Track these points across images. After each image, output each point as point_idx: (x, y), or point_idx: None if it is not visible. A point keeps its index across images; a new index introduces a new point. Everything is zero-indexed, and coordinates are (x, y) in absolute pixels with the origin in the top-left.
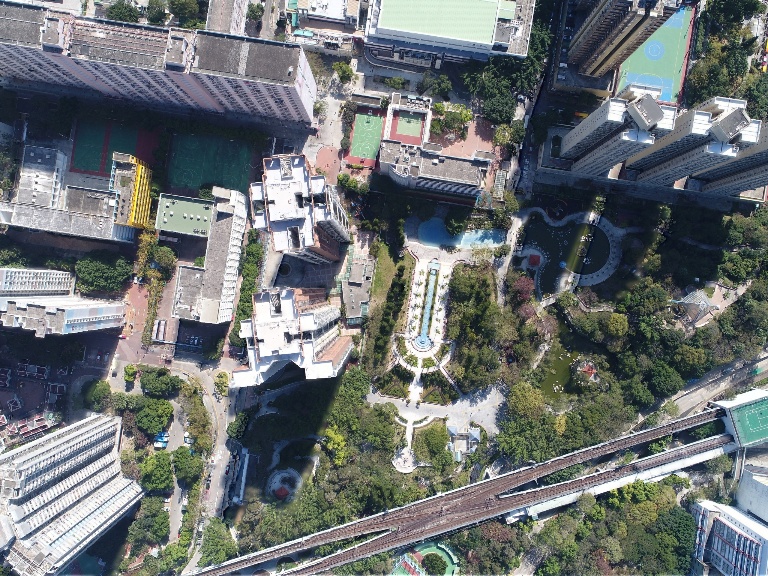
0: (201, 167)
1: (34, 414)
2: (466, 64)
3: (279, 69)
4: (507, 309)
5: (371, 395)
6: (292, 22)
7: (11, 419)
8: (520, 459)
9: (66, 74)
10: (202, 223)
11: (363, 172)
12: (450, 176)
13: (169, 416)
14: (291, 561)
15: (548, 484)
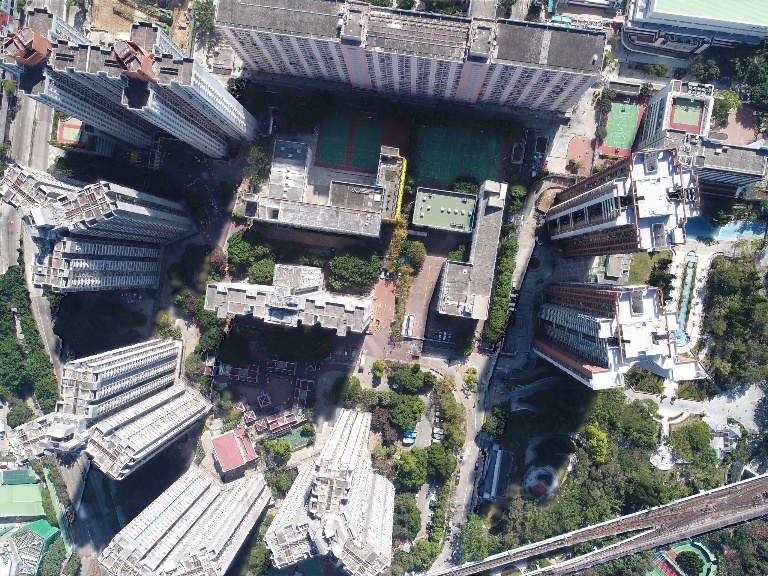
0: (448, 159)
1: (283, 410)
2: (736, 48)
3: (582, 58)
4: None
5: (624, 391)
6: (548, 8)
7: (259, 415)
8: None
9: (330, 67)
10: (459, 217)
11: None
12: (733, 166)
13: None
14: (542, 557)
15: None
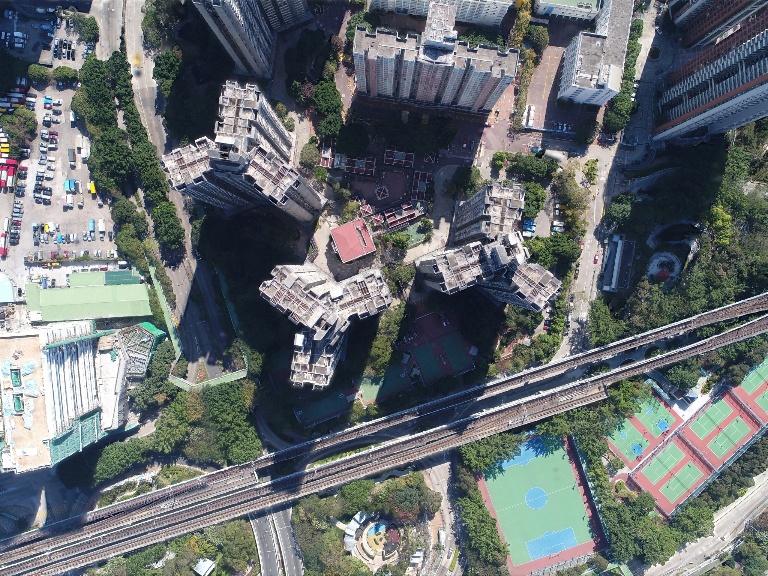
0: None
1: (400, 204)
2: None
3: None
4: None
5: None
6: None
7: (376, 209)
8: None
9: None
10: None
11: None
12: None
13: None
14: None
15: None
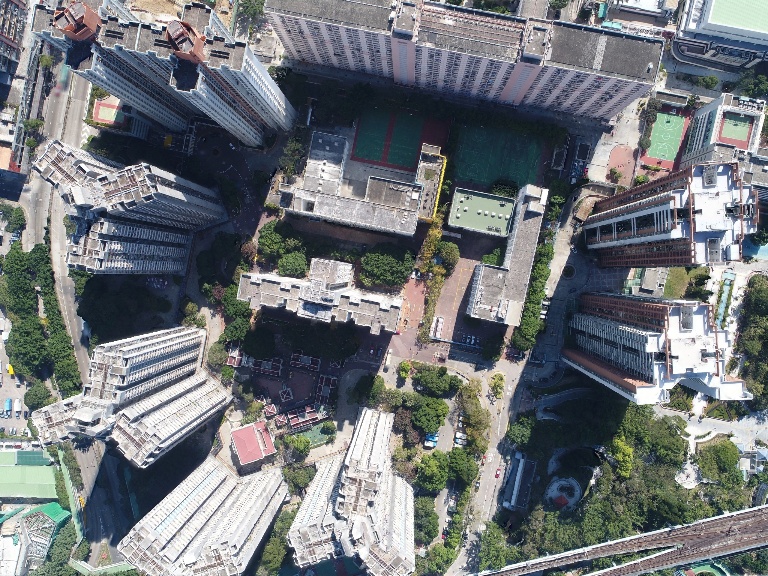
0: (487, 161)
1: (304, 405)
2: None
3: (637, 65)
4: None
5: None
6: (599, 13)
7: (280, 409)
8: None
9: (374, 60)
10: (496, 220)
11: (659, 174)
12: None
13: (445, 416)
14: (558, 570)
15: None
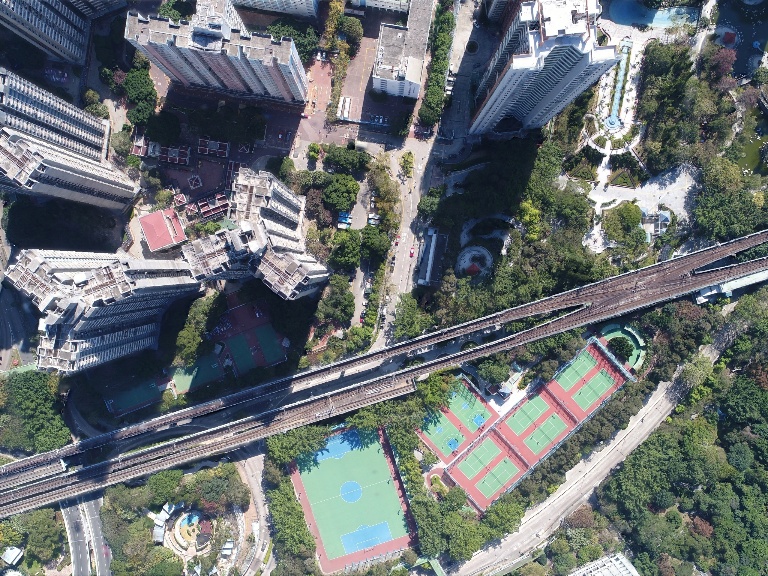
0: None
1: (214, 193)
2: None
3: None
4: (703, 85)
5: (559, 177)
6: None
7: (190, 199)
8: (708, 243)
9: None
10: None
11: None
12: None
13: (356, 193)
14: (475, 345)
15: (741, 262)
